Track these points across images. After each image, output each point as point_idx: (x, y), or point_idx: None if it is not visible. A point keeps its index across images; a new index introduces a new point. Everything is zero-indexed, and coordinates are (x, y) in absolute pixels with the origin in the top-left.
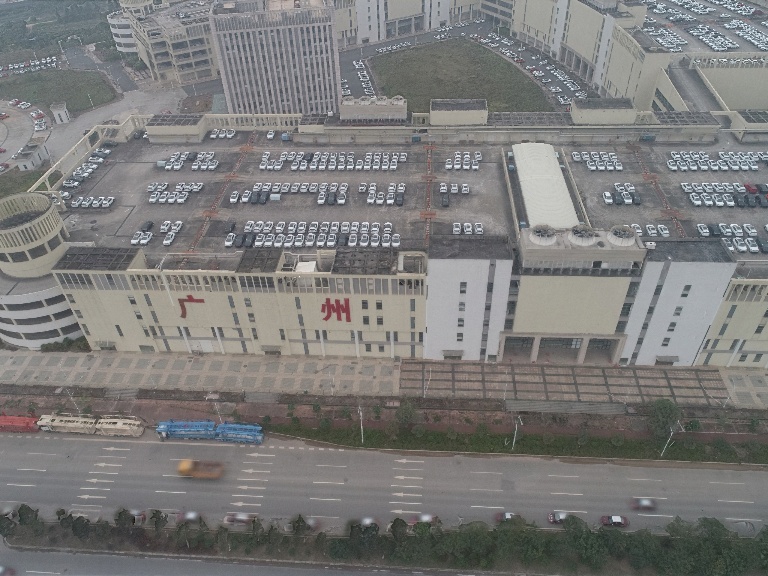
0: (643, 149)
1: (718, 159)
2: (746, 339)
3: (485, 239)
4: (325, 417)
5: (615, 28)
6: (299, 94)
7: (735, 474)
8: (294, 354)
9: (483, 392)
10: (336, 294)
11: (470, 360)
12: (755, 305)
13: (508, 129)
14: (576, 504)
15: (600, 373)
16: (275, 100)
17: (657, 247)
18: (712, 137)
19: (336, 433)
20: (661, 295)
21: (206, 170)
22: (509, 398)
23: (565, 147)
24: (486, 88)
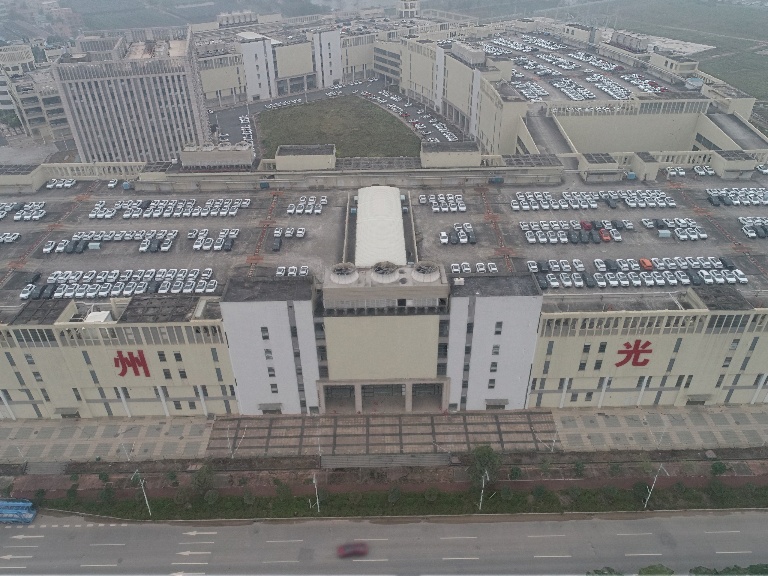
0: (490, 191)
1: (561, 199)
2: (572, 377)
3: (290, 280)
4: (115, 487)
5: (482, 81)
6: (158, 144)
7: (556, 525)
8: (96, 416)
9: (299, 448)
10: (127, 346)
11: (291, 414)
12: (571, 340)
13: (356, 173)
14: (379, 572)
15: (428, 421)
16: (132, 151)
17: (467, 283)
18: (558, 178)
19: (121, 505)
20: (474, 333)
21: (30, 220)
22: (326, 454)
23: (414, 190)
24: (366, 140)
